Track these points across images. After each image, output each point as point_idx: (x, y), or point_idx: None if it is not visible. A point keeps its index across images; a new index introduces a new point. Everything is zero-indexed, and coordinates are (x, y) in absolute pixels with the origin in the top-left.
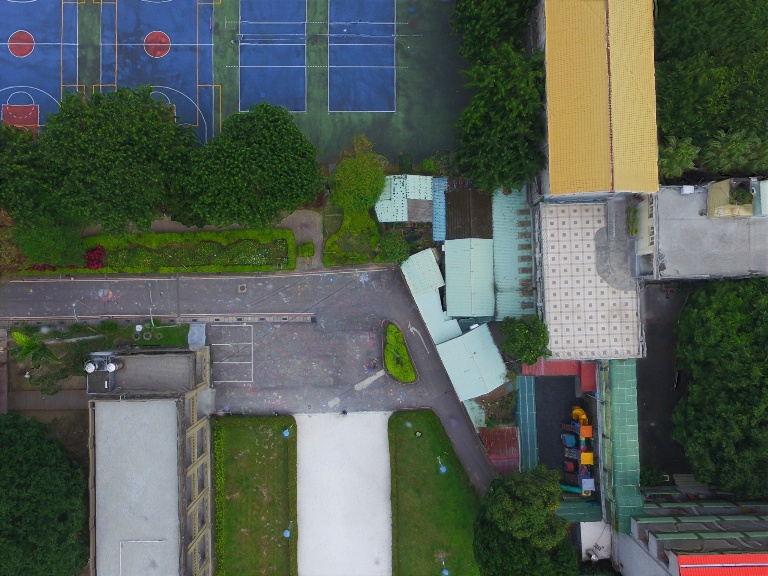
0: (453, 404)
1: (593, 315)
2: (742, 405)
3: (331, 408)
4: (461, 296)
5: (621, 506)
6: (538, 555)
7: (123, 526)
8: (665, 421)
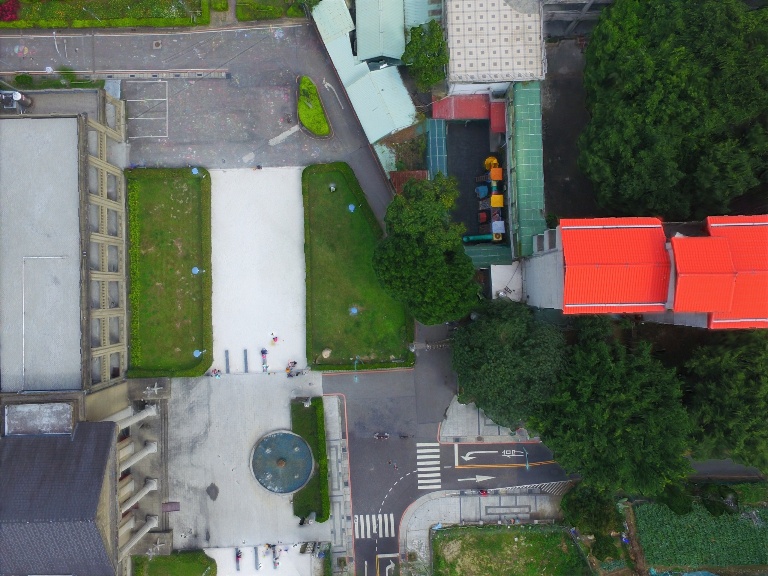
0: (367, 159)
1: (496, 38)
2: (638, 105)
3: (246, 163)
4: (370, 37)
5: (524, 227)
6: (430, 248)
7: (26, 243)
8: (578, 171)
